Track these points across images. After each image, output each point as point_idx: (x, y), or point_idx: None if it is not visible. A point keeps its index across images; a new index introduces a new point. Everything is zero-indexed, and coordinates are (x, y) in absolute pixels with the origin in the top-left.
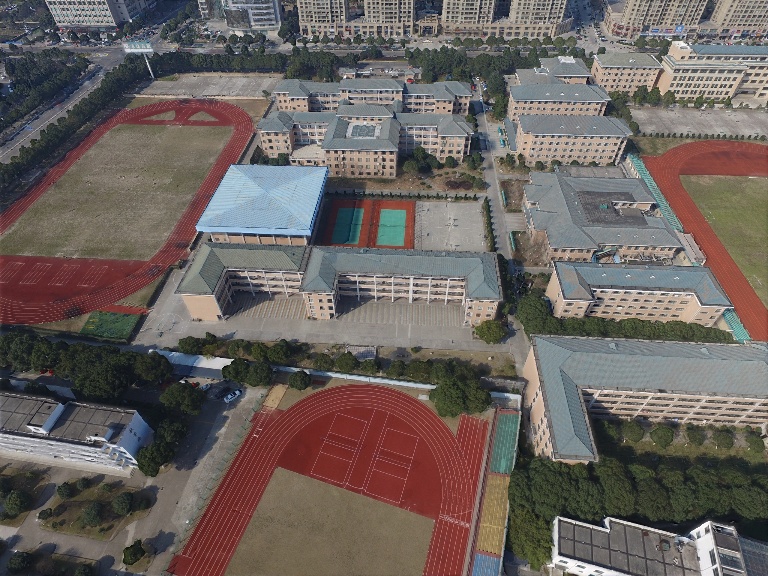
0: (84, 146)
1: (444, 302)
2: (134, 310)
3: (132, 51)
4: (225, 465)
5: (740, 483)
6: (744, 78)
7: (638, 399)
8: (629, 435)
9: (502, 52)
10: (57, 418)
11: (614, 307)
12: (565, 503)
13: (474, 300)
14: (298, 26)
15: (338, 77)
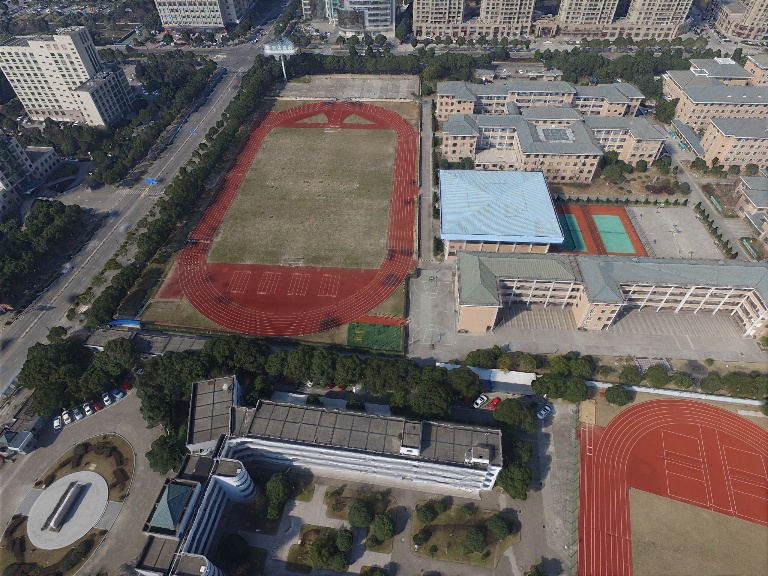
0: (250, 150)
1: (712, 312)
2: (391, 321)
3: (272, 53)
4: (574, 486)
5: None
6: None
7: None
8: None
9: (629, 53)
10: None
11: None
12: None
13: None
14: (409, 27)
15: (478, 79)
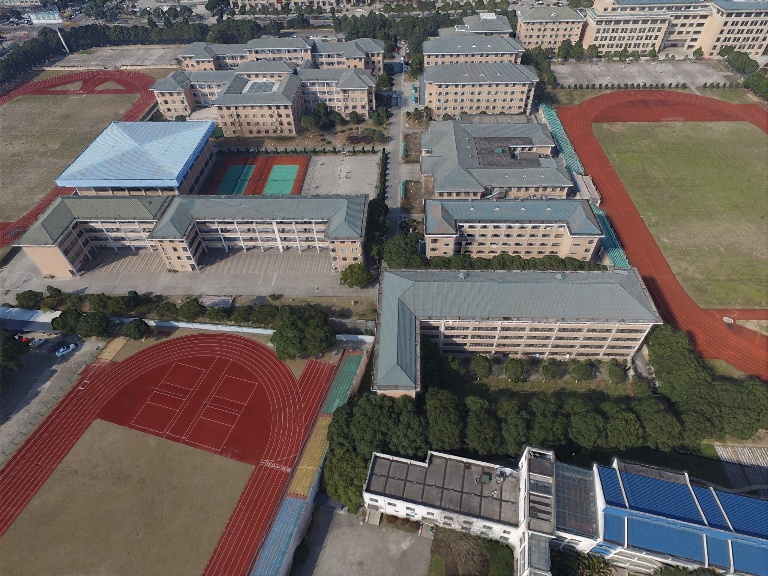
0: None
1: (317, 250)
2: None
3: (41, 23)
4: (39, 419)
5: (578, 410)
6: (670, 29)
7: (488, 331)
8: (476, 369)
9: None
10: None
11: (487, 245)
12: (385, 439)
13: (334, 241)
14: (229, 0)
15: None
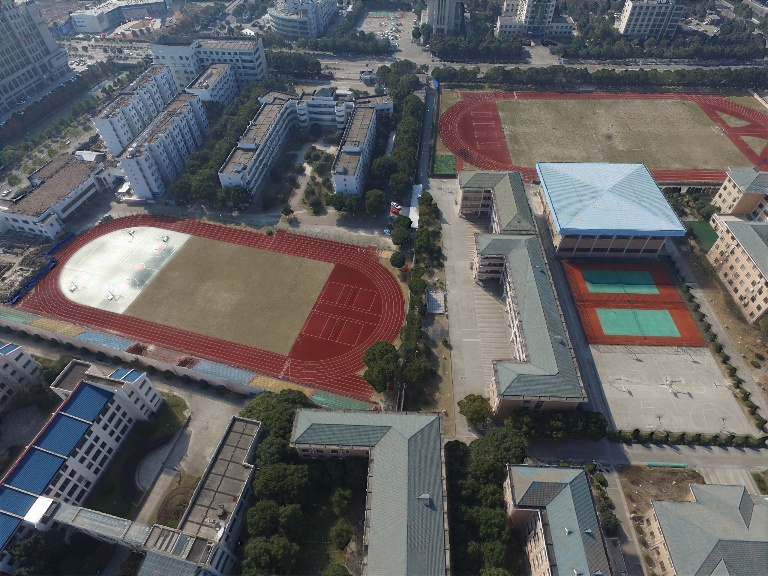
0: (644, 96)
1: None
2: None
3: None
4: (338, 239)
5: None
6: None
7: None
8: None
9: None
10: (352, 151)
11: (539, 572)
12: None
13: None
14: None
15: None
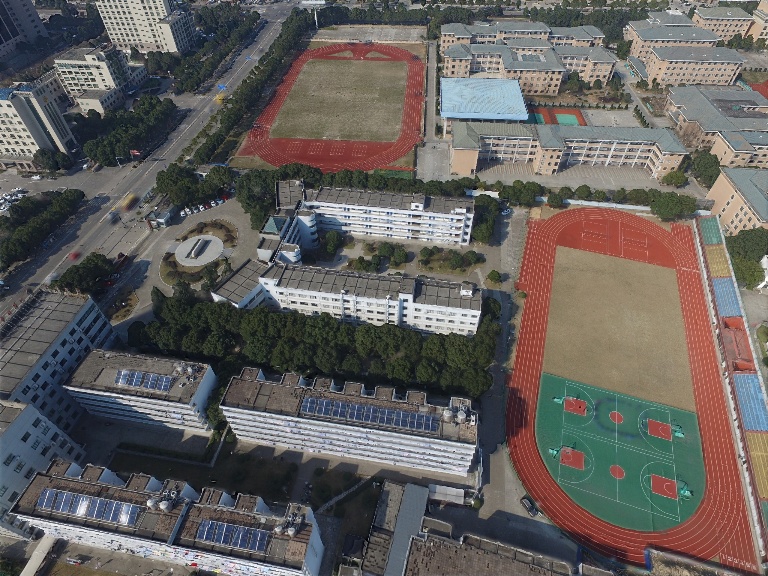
0: (293, 73)
1: (631, 166)
2: (404, 169)
3: (307, 3)
4: (522, 244)
5: None
6: None
7: None
8: None
9: None
10: (424, 203)
11: (764, 163)
12: (767, 250)
13: (667, 154)
14: None
15: None
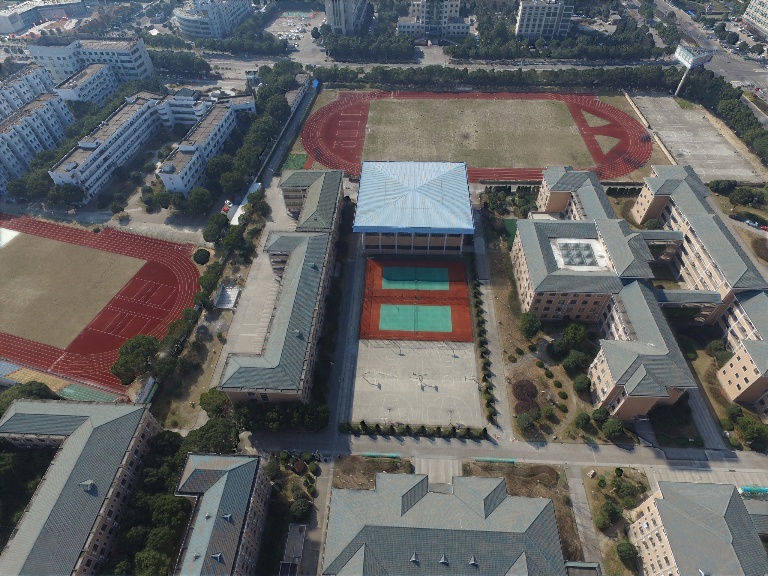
0: (518, 96)
1: None
2: None
3: (678, 58)
4: (160, 237)
5: None
6: None
7: None
8: None
9: None
10: (187, 150)
11: None
12: None
13: None
14: None
15: None
